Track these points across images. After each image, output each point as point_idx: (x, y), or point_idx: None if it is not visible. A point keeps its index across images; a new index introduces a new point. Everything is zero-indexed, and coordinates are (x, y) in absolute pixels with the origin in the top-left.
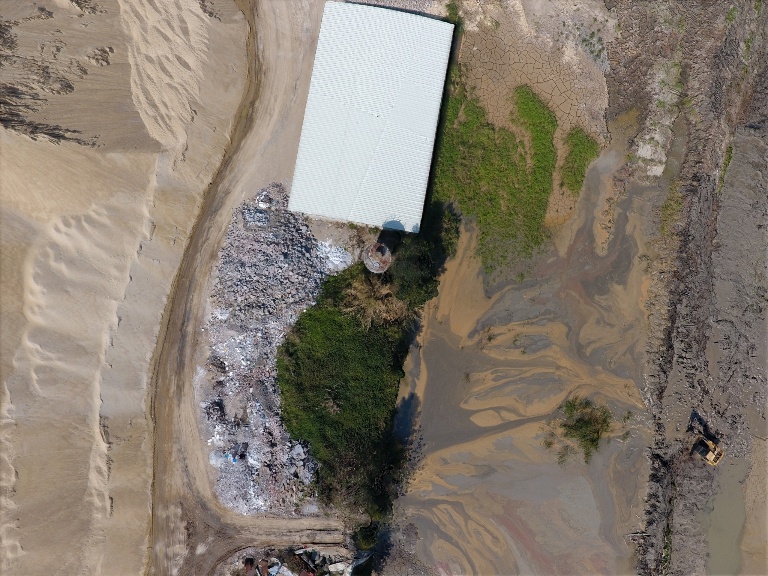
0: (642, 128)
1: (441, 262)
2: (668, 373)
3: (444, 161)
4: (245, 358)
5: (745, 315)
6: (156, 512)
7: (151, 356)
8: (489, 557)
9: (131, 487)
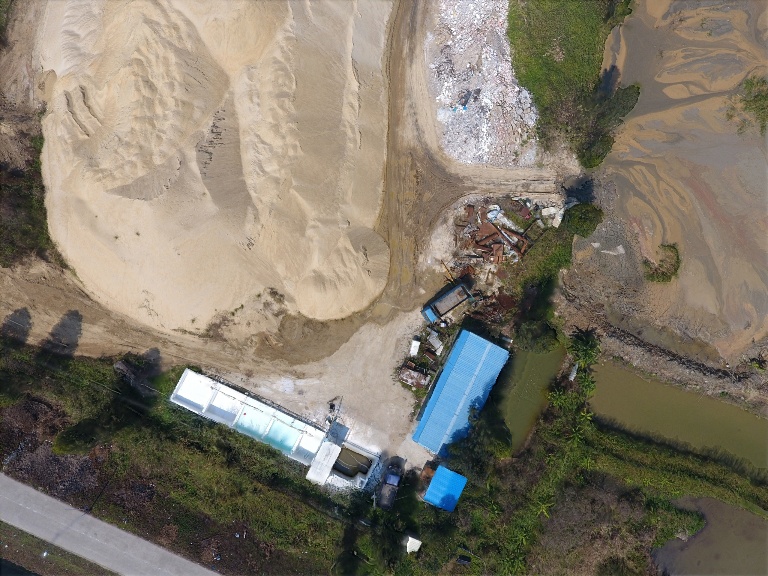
0: None
1: None
2: None
3: None
4: (479, 13)
5: None
6: (389, 161)
7: (387, 20)
8: (677, 215)
9: (373, 130)
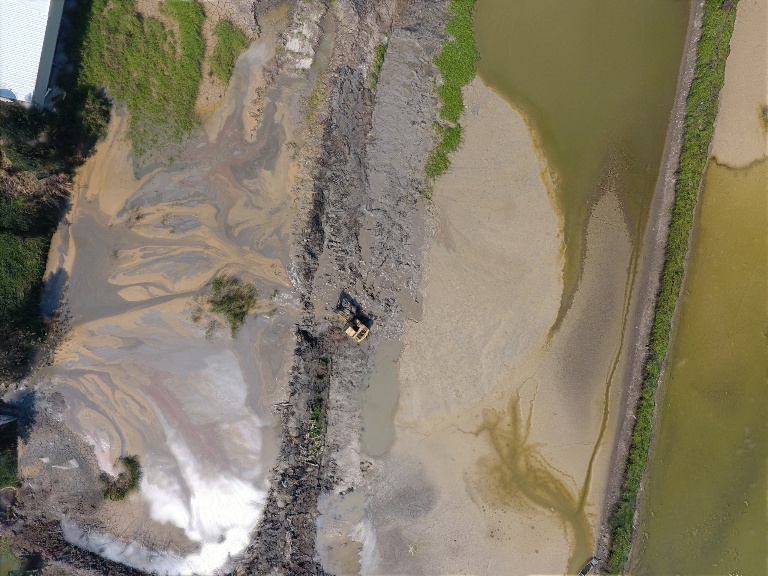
0: (291, 23)
1: (91, 144)
2: (319, 256)
3: (91, 46)
4: None
5: (400, 205)
6: None
7: None
8: (137, 425)
9: None
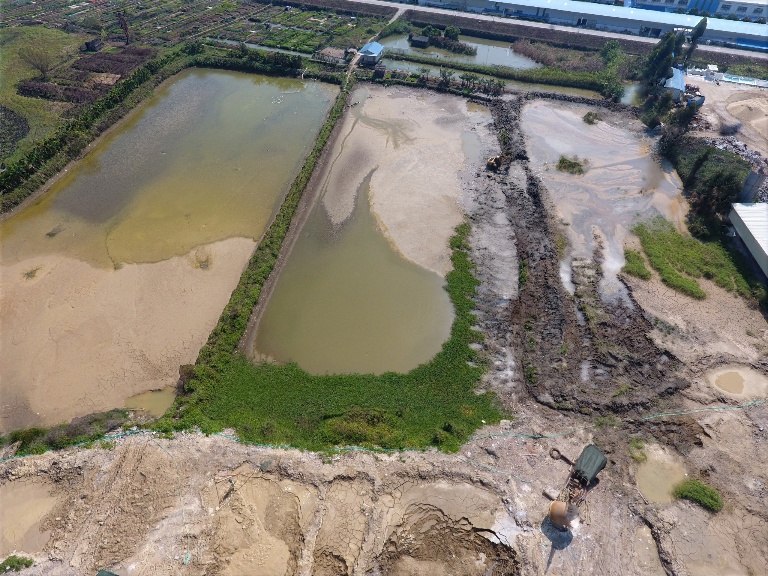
0: (598, 284)
1: None
2: None
3: None
4: None
5: None
6: (764, 139)
7: None
8: None
9: None
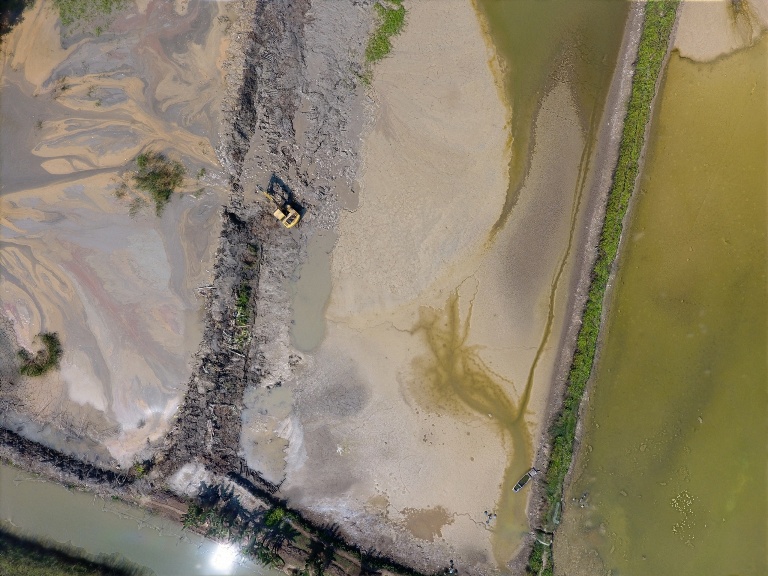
0: None
1: (18, 11)
2: (250, 137)
3: None
4: None
5: (338, 90)
6: None
7: None
8: (57, 302)
9: None
